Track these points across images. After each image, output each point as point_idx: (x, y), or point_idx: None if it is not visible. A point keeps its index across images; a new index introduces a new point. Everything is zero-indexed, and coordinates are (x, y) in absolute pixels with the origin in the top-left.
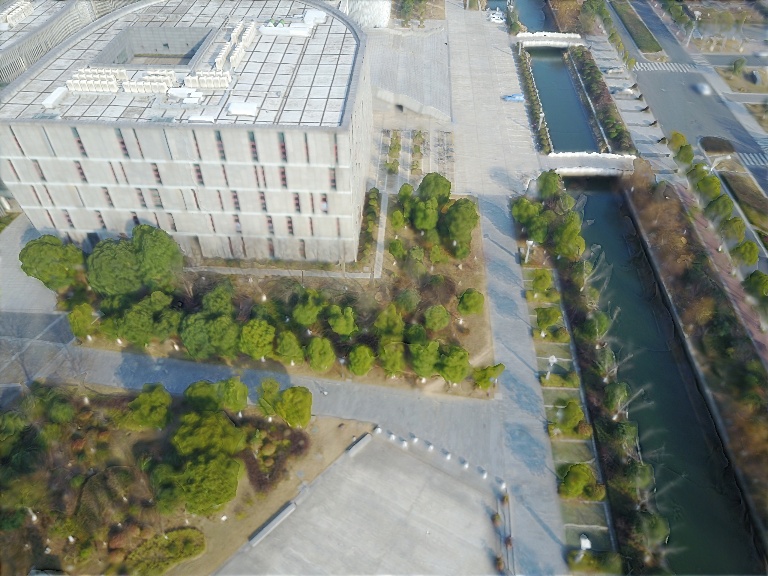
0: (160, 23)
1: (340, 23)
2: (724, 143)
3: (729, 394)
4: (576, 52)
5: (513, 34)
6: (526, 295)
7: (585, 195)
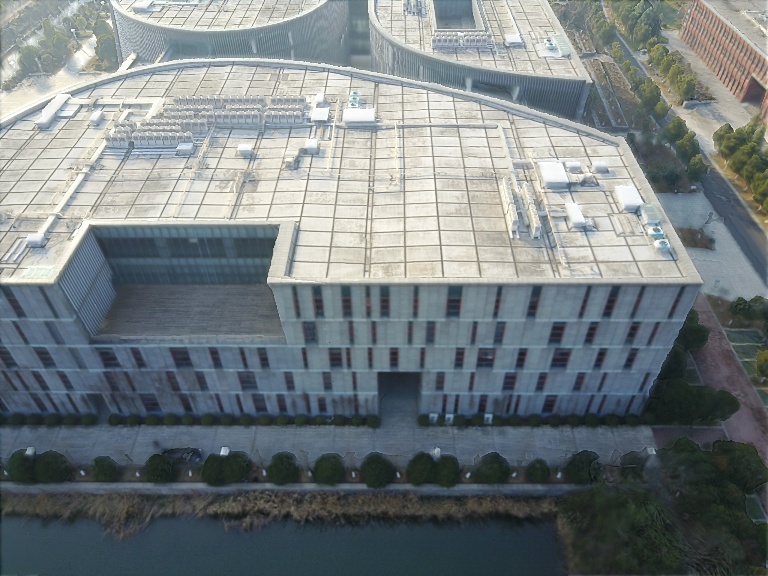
0: (279, 2)
1: (123, 5)
2: None
3: (32, 22)
4: None
5: None
6: (91, 35)
7: None
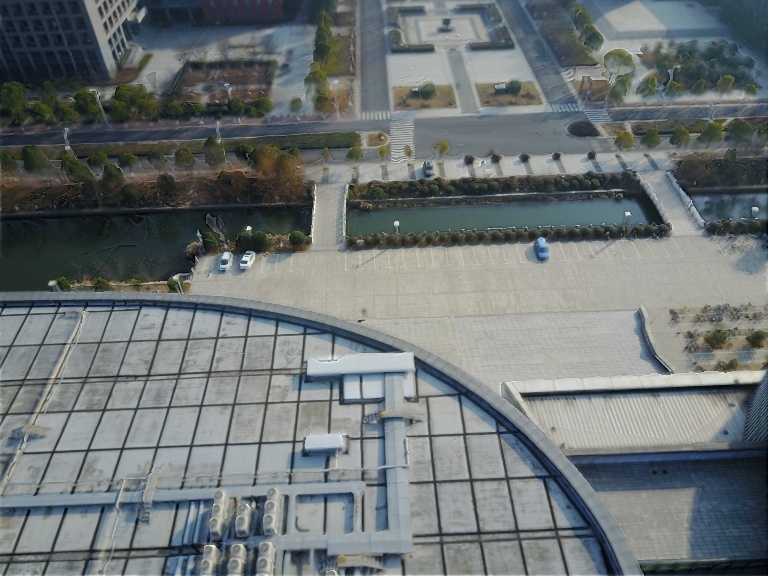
0: None
1: None
2: (580, 125)
3: None
4: (366, 193)
5: (305, 246)
6: None
7: (712, 216)
